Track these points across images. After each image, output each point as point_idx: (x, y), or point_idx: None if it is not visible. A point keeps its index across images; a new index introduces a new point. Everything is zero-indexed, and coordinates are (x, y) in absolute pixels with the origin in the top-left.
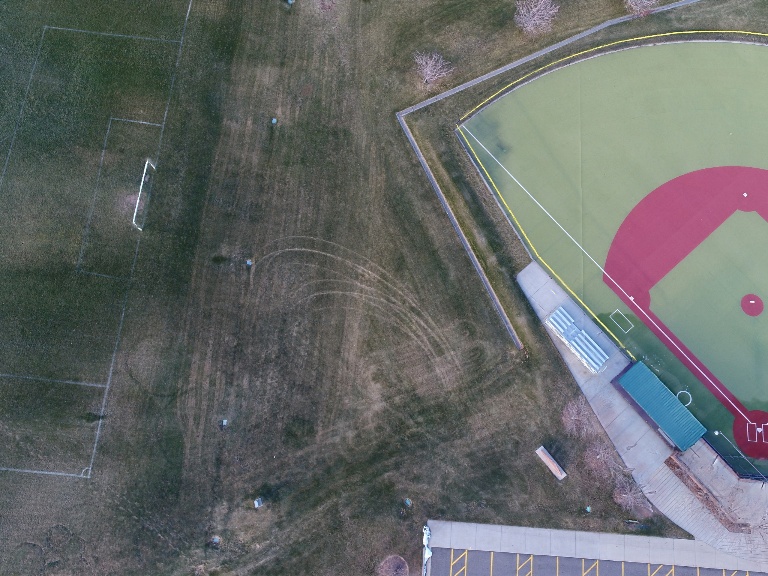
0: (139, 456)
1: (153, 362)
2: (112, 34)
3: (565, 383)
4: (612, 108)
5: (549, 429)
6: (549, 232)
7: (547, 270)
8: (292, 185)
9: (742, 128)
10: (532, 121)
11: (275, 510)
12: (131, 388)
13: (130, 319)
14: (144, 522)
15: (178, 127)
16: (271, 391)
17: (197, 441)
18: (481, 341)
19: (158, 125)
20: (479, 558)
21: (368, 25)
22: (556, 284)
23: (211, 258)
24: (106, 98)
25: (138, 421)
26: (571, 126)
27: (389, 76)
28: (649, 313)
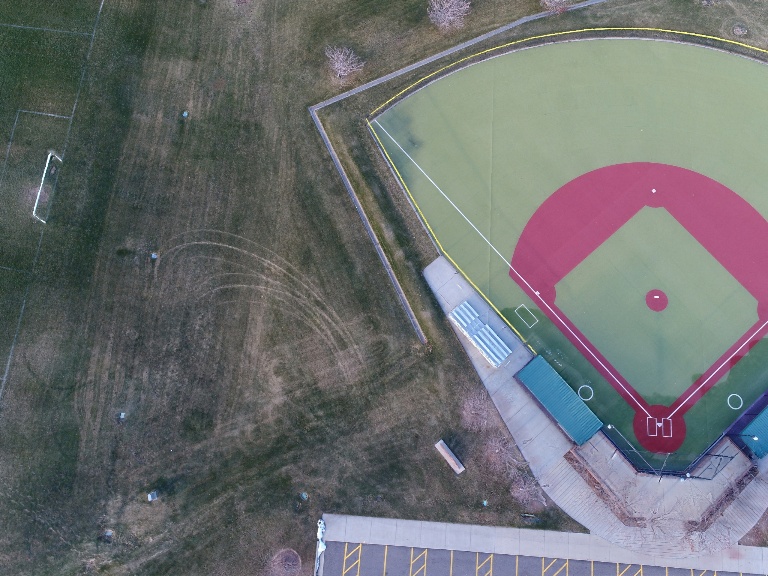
0: (34, 449)
1: (52, 355)
2: (23, 26)
3: (467, 377)
4: (525, 104)
5: (449, 423)
6: (457, 227)
7: (454, 265)
8: (201, 178)
9: (653, 125)
10: (444, 116)
11: (170, 503)
12: (28, 381)
13: (30, 312)
14: (36, 515)
15: (87, 120)
16: (171, 384)
17: (93, 434)
18: (385, 335)
19: (66, 117)
20: (373, 552)
21: (283, 19)
22: (462, 279)
23: (115, 251)
24: (15, 90)
25: (34, 414)
26: (483, 121)
27: (303, 70)
28: (554, 308)
